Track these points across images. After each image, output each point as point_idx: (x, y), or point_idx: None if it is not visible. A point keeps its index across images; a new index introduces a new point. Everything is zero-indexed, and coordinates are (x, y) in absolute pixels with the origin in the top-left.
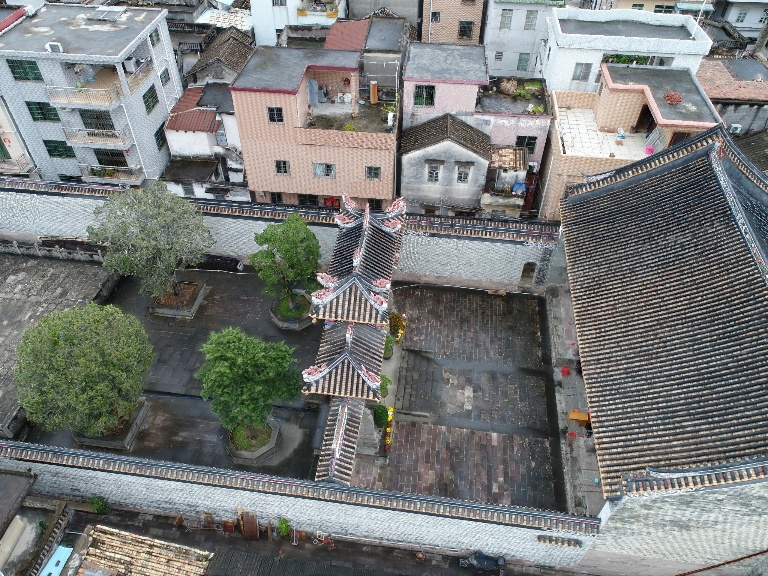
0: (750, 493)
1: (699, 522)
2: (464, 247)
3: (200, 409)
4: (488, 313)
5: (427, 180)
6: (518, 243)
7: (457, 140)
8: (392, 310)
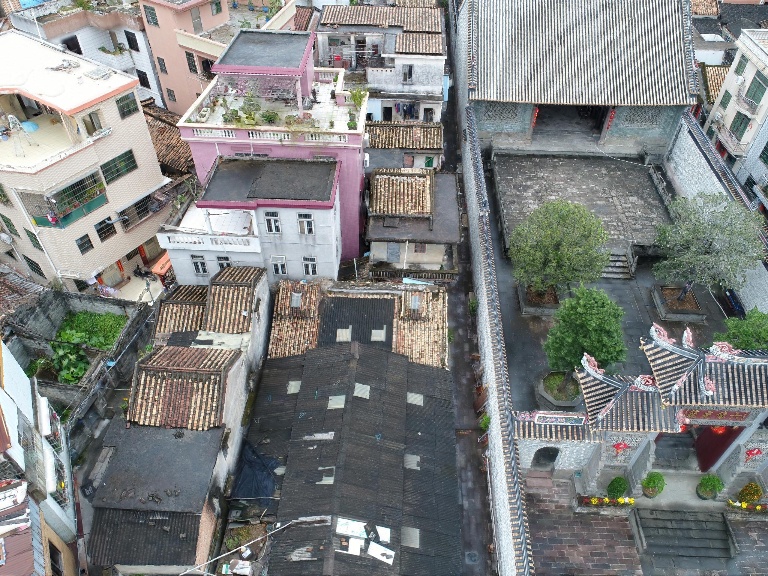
0: None
1: None
2: None
3: None
4: None
5: None
6: None
7: None
8: None
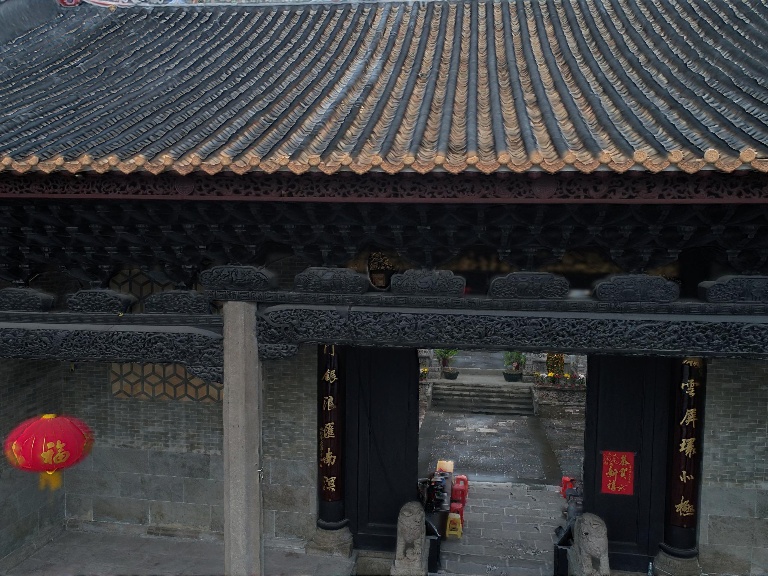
0: None
1: None
2: None
3: None
4: None
5: None
6: None
7: None
8: (578, 364)
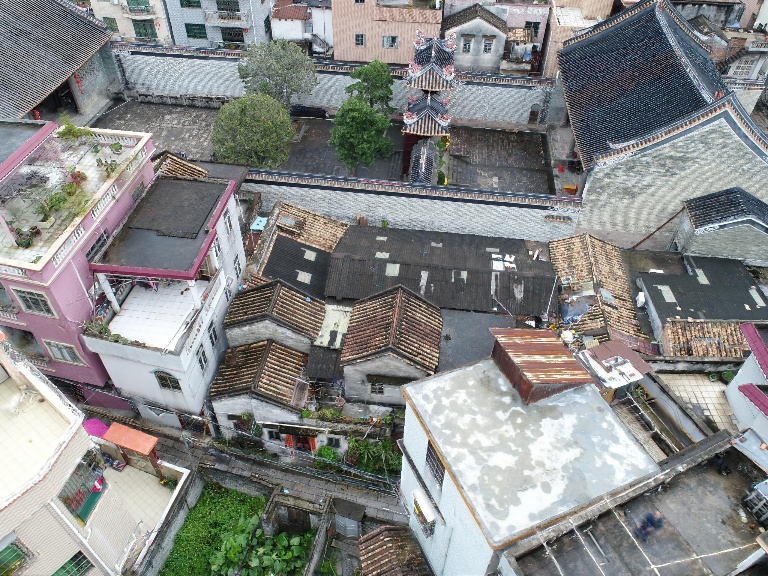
0: (664, 154)
1: (639, 188)
2: (490, 93)
3: None
4: (506, 141)
5: (462, 51)
6: (528, 88)
7: (485, 18)
8: None
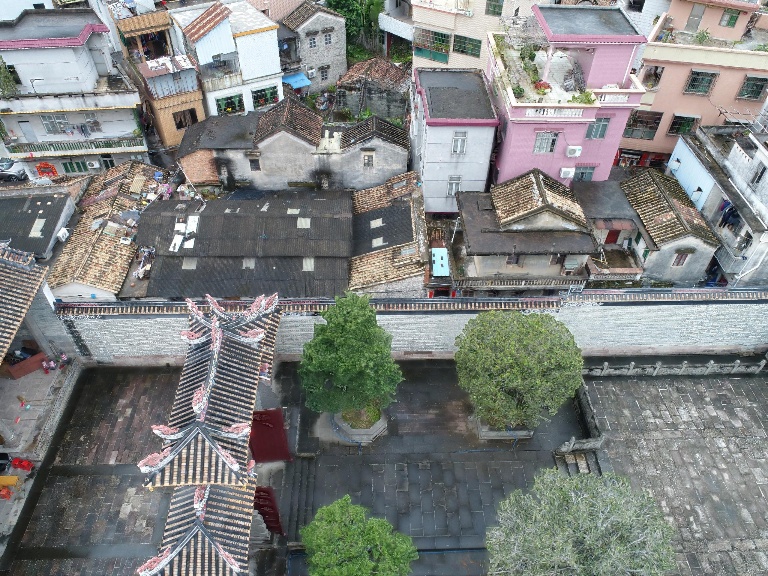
0: None
1: None
2: None
3: (427, 443)
4: None
5: None
6: None
7: None
8: None
